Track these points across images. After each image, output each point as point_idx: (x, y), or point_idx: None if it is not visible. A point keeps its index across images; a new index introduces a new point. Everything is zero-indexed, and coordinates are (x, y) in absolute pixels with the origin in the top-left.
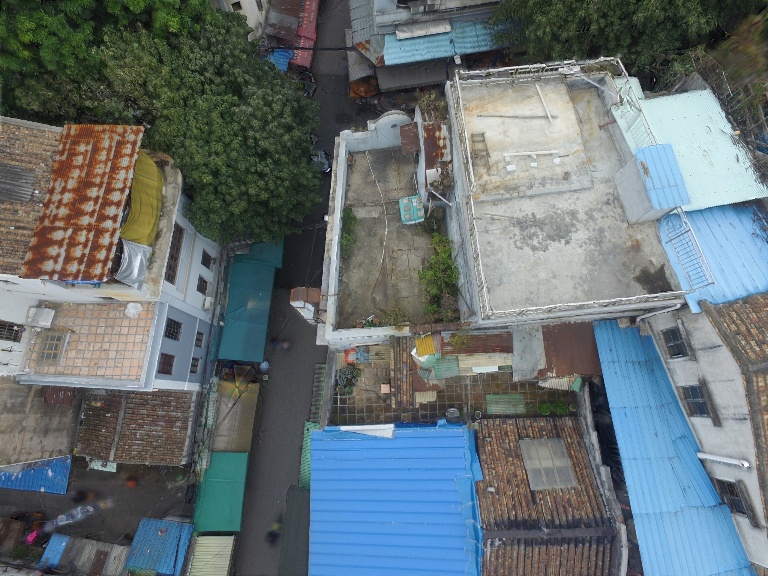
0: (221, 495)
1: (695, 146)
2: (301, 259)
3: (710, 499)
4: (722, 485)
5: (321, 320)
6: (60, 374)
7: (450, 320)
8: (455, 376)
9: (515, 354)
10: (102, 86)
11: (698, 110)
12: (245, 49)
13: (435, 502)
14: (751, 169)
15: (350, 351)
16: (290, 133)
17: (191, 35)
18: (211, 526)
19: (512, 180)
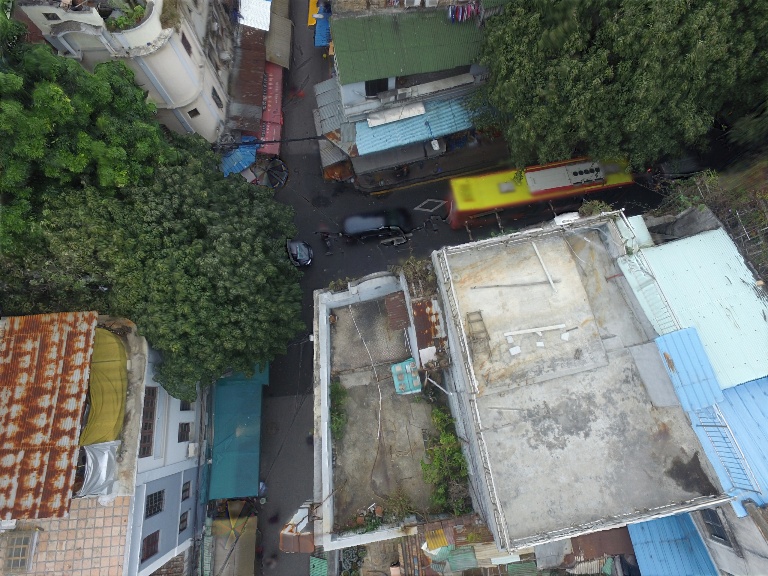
0: None
1: (716, 303)
2: (289, 362)
3: None
4: None
5: (317, 517)
6: None
7: (462, 512)
8: None
9: None
10: (47, 262)
11: (713, 257)
12: (206, 173)
13: None
14: None
15: None
16: (263, 269)
17: (144, 178)
18: None
19: (518, 365)
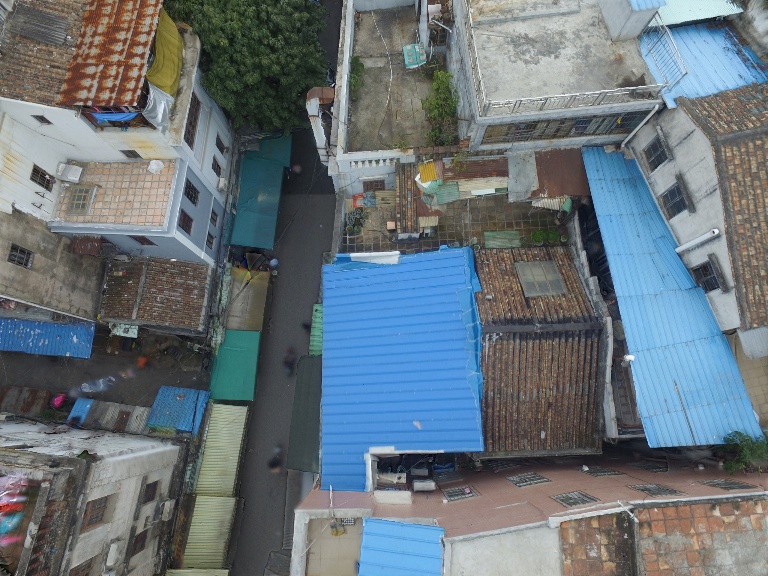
0: (235, 368)
1: None
2: (307, 168)
3: (686, 284)
4: (697, 273)
5: (332, 152)
6: (88, 222)
7: (451, 145)
8: (455, 200)
9: (510, 177)
10: None
11: None
12: None
13: (438, 313)
14: None
15: (358, 197)
16: (299, 14)
17: None
18: (226, 396)
19: (506, 5)
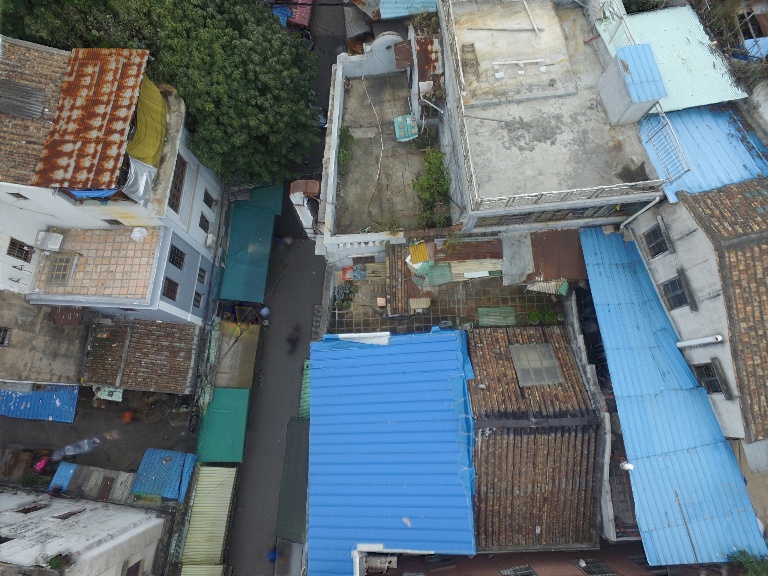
0: (223, 428)
1: (674, 55)
2: None
3: (688, 383)
4: (700, 371)
5: (320, 231)
6: (69, 294)
7: (443, 226)
8: (448, 282)
9: (505, 260)
10: (108, 15)
11: (677, 23)
12: None
13: (429, 401)
14: (727, 75)
15: (348, 269)
16: (289, 70)
17: None
18: (214, 457)
19: (500, 86)
